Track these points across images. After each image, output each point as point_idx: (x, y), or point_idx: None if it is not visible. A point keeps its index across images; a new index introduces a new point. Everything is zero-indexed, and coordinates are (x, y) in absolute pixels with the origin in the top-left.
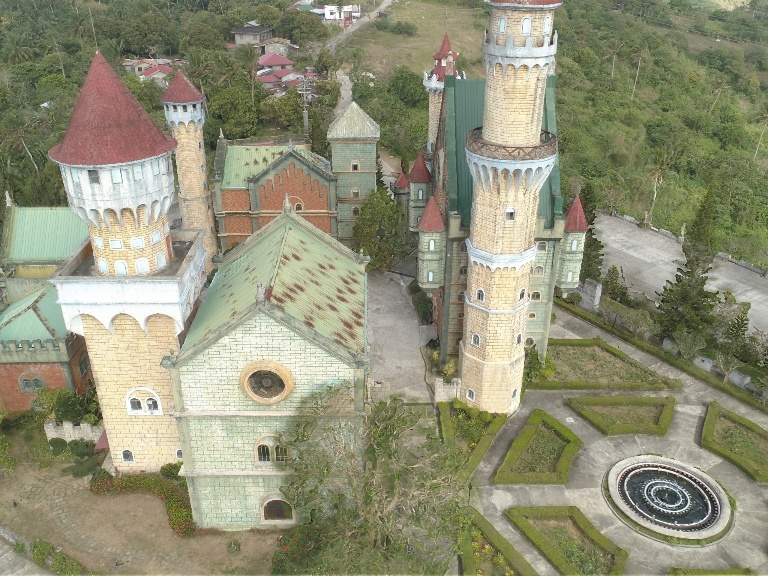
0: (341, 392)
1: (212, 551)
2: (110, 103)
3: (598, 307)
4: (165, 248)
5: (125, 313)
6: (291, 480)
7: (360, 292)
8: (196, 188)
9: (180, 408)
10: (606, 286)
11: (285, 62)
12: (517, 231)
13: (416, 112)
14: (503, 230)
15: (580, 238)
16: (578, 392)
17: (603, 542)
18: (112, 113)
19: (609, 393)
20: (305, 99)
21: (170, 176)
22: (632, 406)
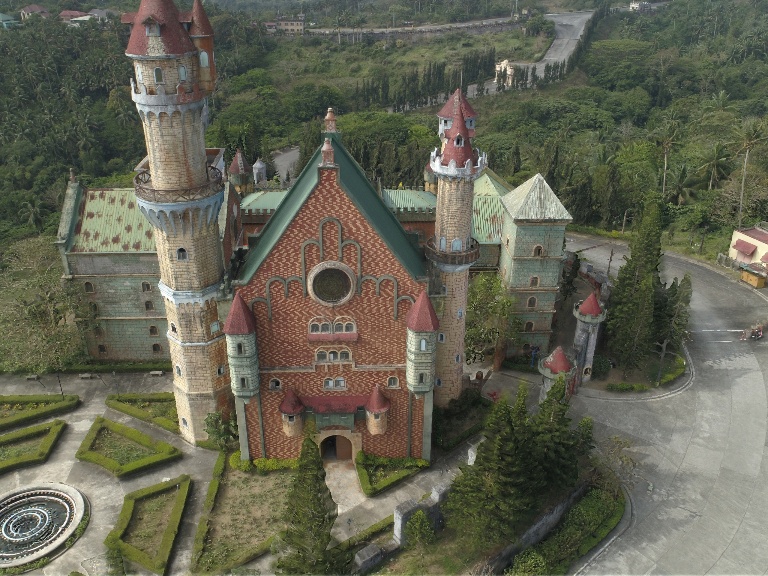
0: None
1: None
2: None
3: (399, 542)
4: None
5: None
6: None
7: None
8: None
9: None
10: None
11: None
12: None
13: None
14: None
15: None
16: None
17: None
18: None
19: None
20: None
21: None
22: None
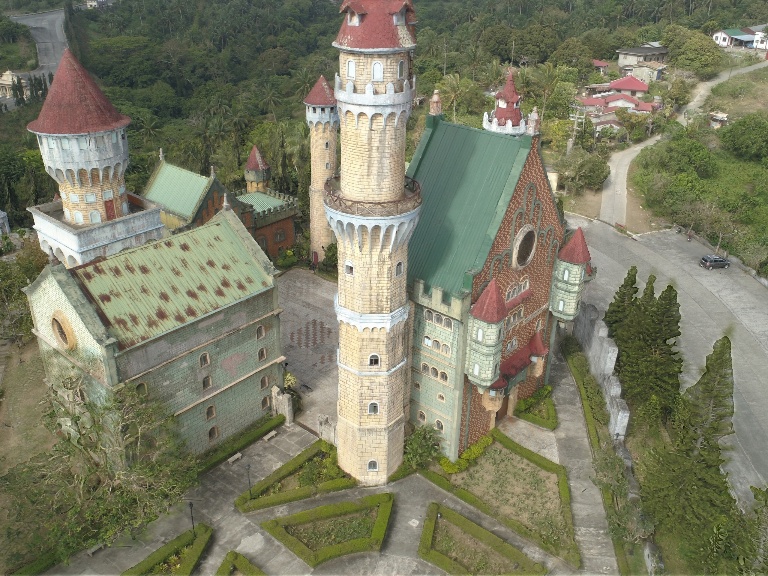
0: (99, 362)
1: (50, 449)
2: (60, 88)
3: (622, 438)
4: (103, 209)
5: (60, 248)
6: (91, 422)
7: (232, 297)
8: (319, 182)
9: (36, 328)
10: (642, 418)
11: (637, 88)
12: (357, 288)
13: (748, 167)
14: (345, 282)
15: (486, 328)
16: (464, 504)
17: None
18: (59, 96)
19: (494, 524)
20: (575, 127)
21: (103, 153)
22: (492, 549)
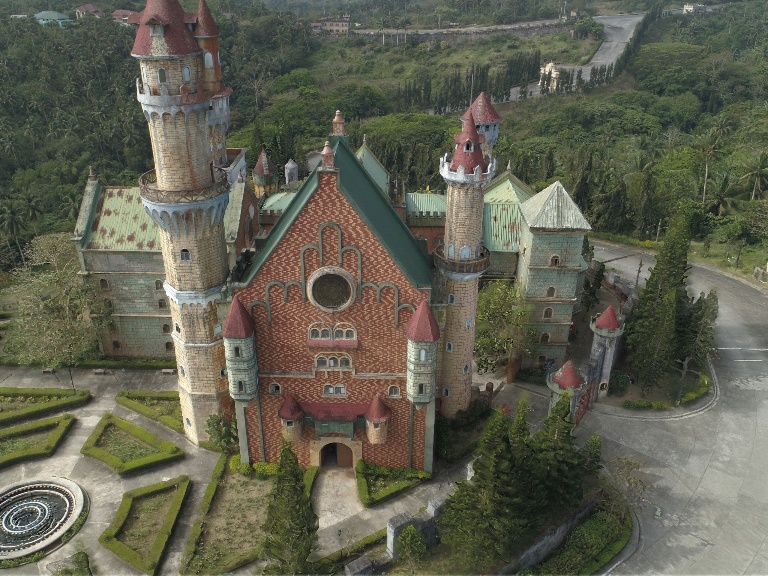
0: None
1: None
2: None
3: (392, 556)
4: None
5: None
6: None
7: None
8: None
9: None
10: None
11: None
12: None
13: None
14: None
15: None
16: None
17: (6, 456)
18: None
19: None
20: None
21: None
22: None
